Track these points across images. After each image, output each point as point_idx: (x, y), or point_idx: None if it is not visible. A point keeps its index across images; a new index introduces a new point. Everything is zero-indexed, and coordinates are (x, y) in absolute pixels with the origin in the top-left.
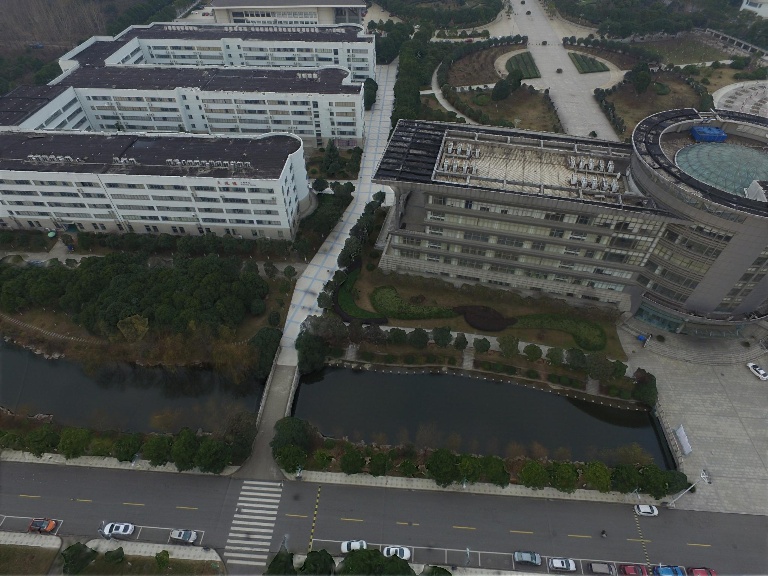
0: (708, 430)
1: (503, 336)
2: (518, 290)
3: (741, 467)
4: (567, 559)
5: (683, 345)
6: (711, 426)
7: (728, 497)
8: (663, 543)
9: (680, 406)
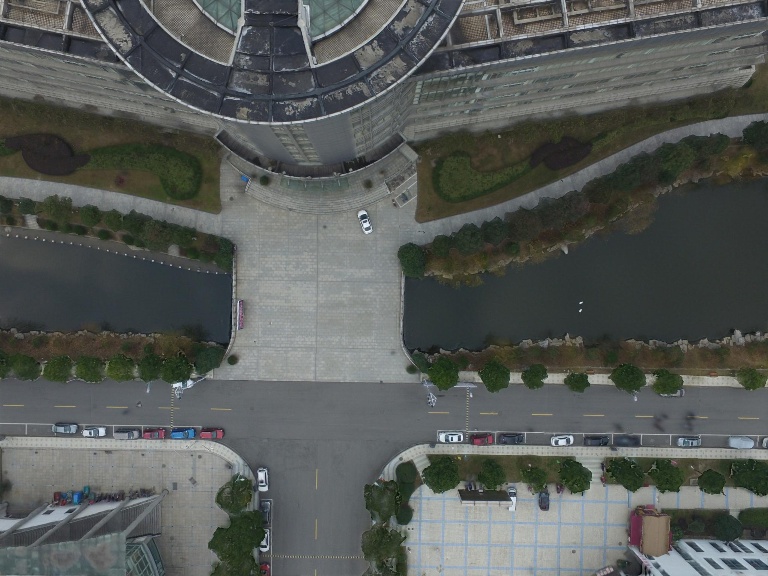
0: (277, 298)
1: (73, 182)
2: (93, 105)
3: (293, 337)
4: (97, 429)
5: (290, 189)
6: (282, 293)
7: (266, 366)
8: (190, 409)
9: (259, 271)
